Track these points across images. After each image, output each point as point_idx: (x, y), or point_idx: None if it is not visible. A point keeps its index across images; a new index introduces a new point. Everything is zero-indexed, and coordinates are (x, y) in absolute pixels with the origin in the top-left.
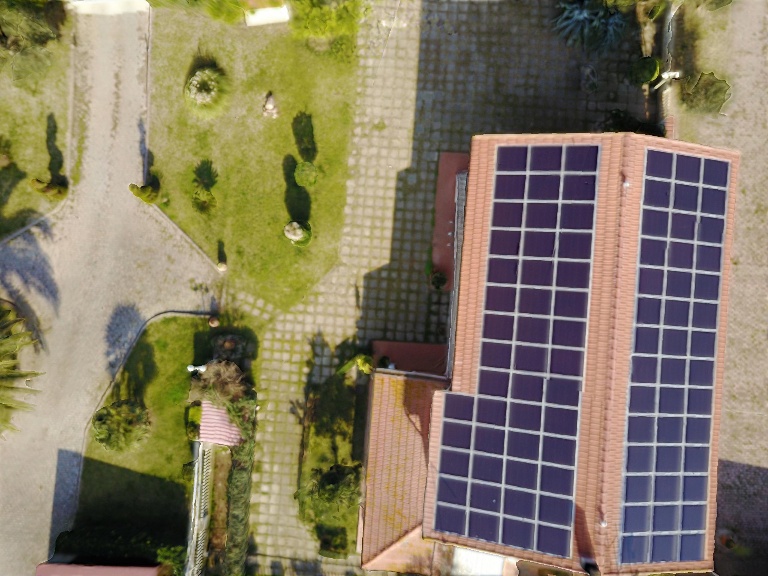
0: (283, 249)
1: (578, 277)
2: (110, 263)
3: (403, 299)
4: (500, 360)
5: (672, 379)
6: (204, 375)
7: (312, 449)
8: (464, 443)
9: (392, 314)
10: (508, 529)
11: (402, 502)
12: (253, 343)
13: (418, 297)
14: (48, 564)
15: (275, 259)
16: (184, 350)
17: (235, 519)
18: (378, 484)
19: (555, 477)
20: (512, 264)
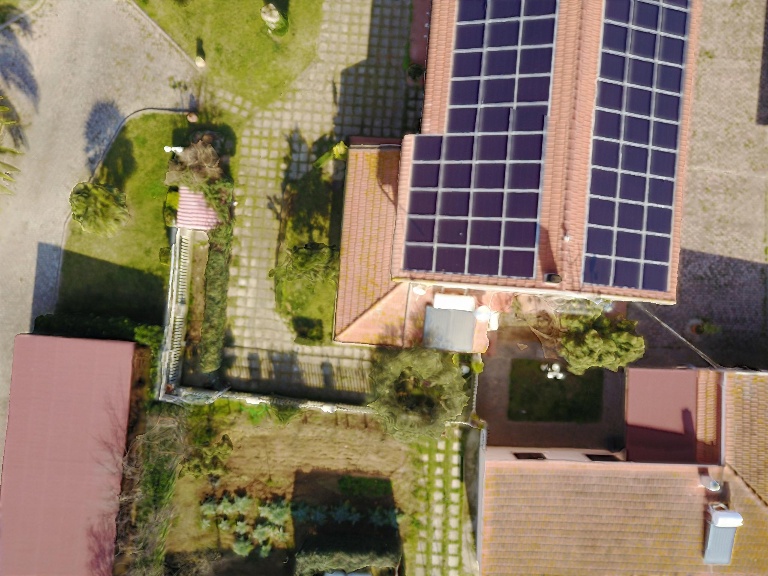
0: (261, 46)
1: (545, 4)
2: (89, 61)
3: (380, 95)
4: (468, 97)
5: (637, 109)
6: (181, 158)
7: (289, 243)
8: (432, 181)
9: (369, 110)
10: (474, 259)
11: (374, 271)
12: (231, 140)
13: (395, 93)
14: (26, 335)
15: (253, 56)
16: (163, 146)
17: (211, 300)
18: (351, 256)
19: (520, 203)
20: (481, 1)
